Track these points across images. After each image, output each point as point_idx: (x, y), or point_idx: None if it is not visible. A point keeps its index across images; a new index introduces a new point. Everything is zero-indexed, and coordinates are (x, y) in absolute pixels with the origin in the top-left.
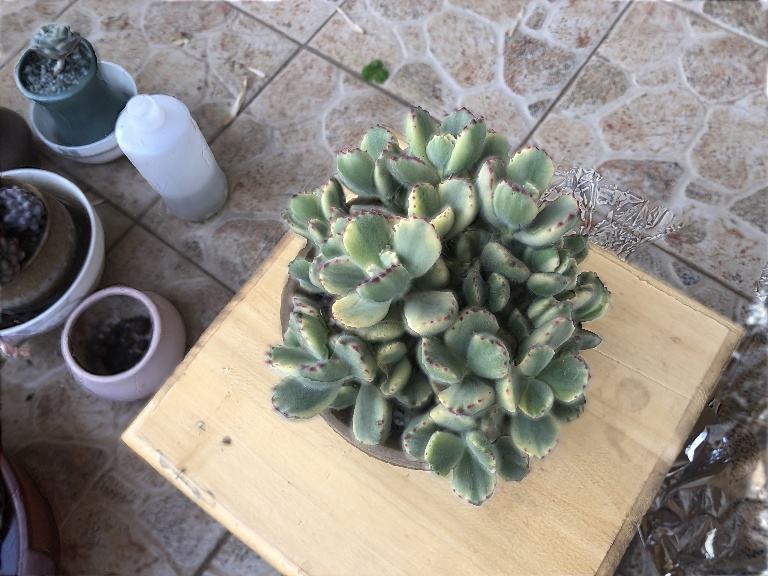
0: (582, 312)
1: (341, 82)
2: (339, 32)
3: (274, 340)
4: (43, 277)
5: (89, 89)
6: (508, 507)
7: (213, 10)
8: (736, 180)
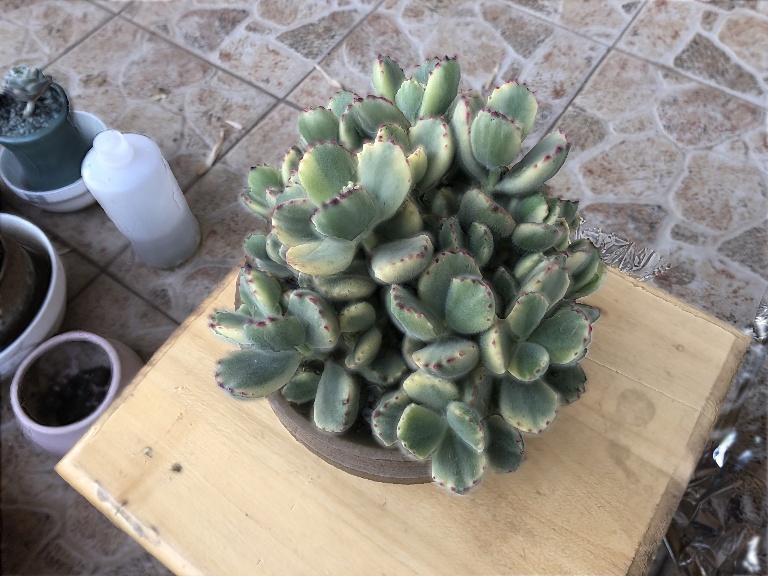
0: (576, 283)
1: None
2: (317, 87)
3: None
4: None
5: (58, 132)
6: (501, 538)
7: (192, 68)
8: (721, 222)
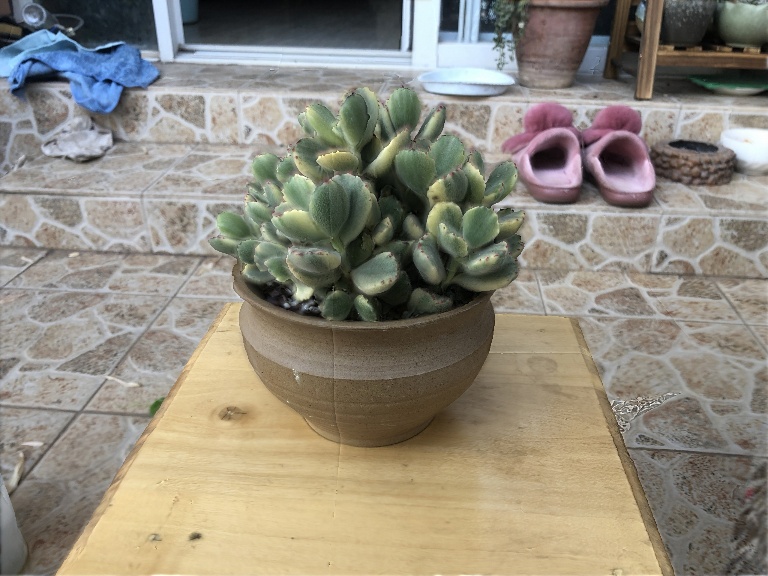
0: None
1: (131, 424)
2: (114, 392)
3: (206, 443)
4: None
5: None
6: (517, 461)
7: None
8: None
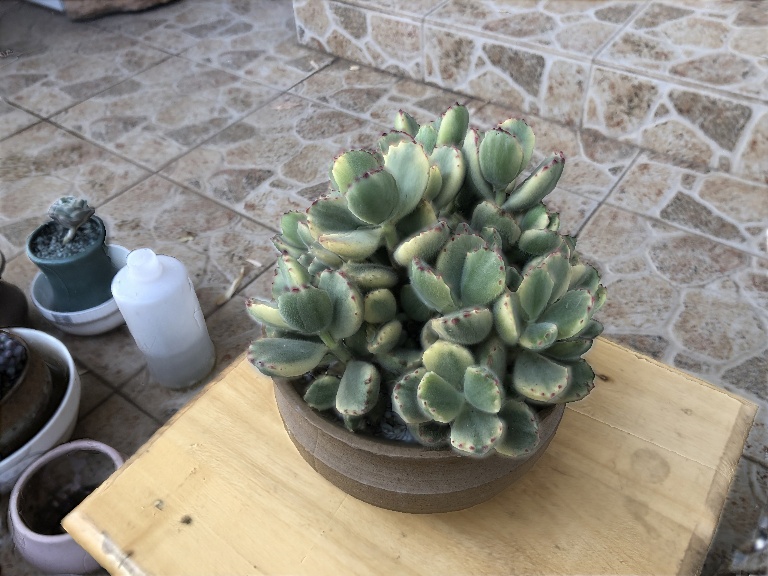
0: None
1: None
2: None
3: (251, 417)
4: (7, 426)
5: (93, 256)
6: None
7: (219, 216)
8: (722, 352)
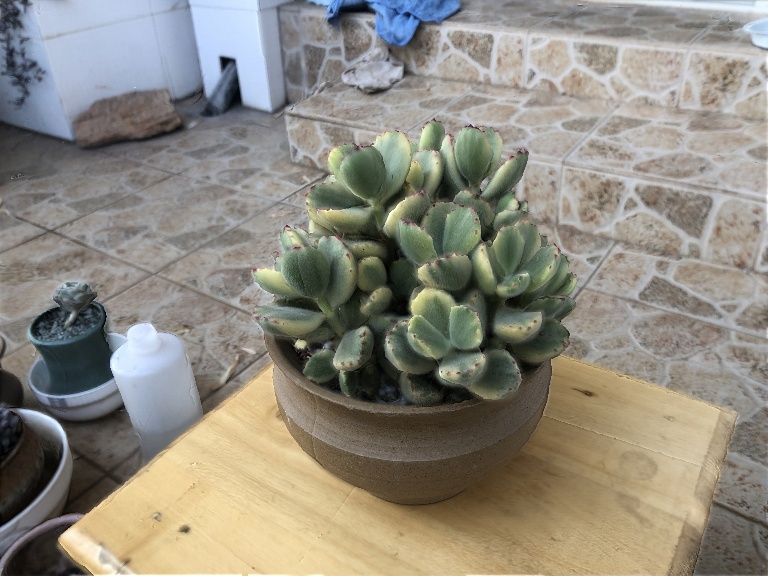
0: (552, 282)
1: None
2: None
3: (250, 438)
4: None
5: (93, 338)
6: None
7: (215, 310)
8: None
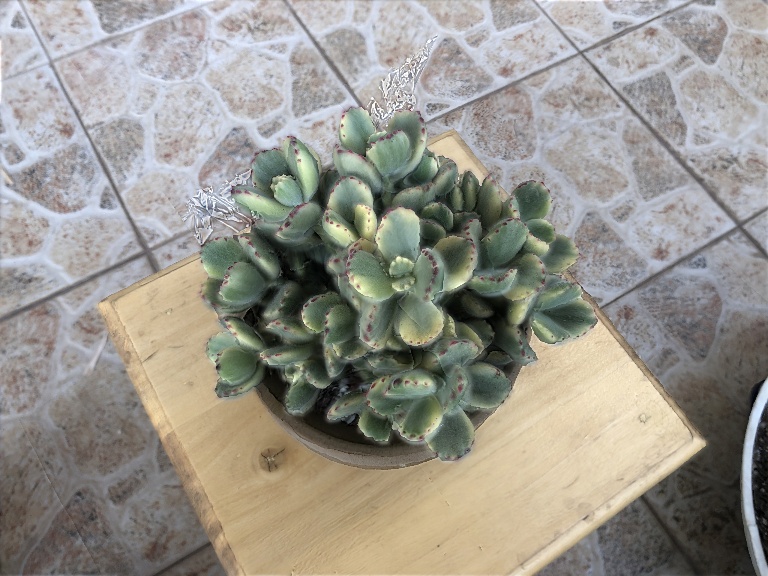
0: None
1: None
2: None
3: (285, 507)
4: None
5: None
6: None
7: None
8: (274, 99)
